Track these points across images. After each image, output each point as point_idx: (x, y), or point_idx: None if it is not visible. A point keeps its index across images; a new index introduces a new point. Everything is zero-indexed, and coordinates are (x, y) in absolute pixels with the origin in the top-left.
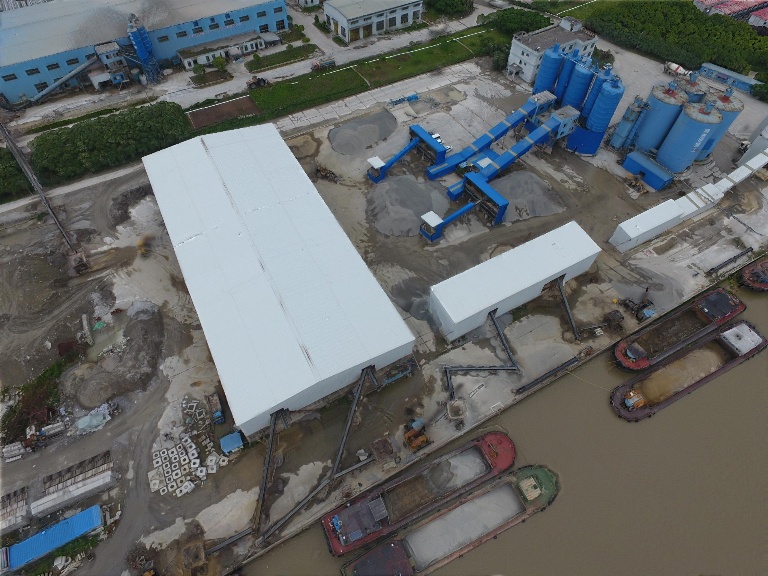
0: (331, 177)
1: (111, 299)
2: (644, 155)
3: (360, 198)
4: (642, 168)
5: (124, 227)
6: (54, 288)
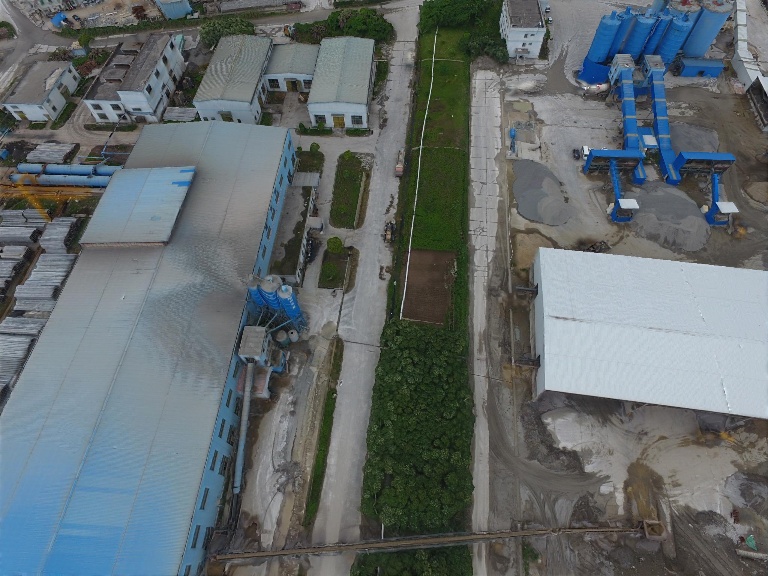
0: (605, 247)
1: (715, 516)
2: (692, 58)
3: (642, 242)
4: (702, 68)
5: (590, 463)
6: (690, 572)
